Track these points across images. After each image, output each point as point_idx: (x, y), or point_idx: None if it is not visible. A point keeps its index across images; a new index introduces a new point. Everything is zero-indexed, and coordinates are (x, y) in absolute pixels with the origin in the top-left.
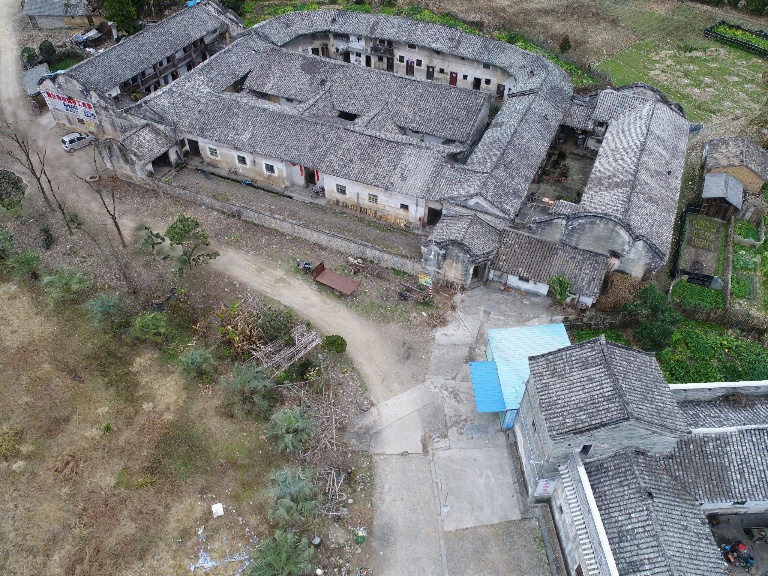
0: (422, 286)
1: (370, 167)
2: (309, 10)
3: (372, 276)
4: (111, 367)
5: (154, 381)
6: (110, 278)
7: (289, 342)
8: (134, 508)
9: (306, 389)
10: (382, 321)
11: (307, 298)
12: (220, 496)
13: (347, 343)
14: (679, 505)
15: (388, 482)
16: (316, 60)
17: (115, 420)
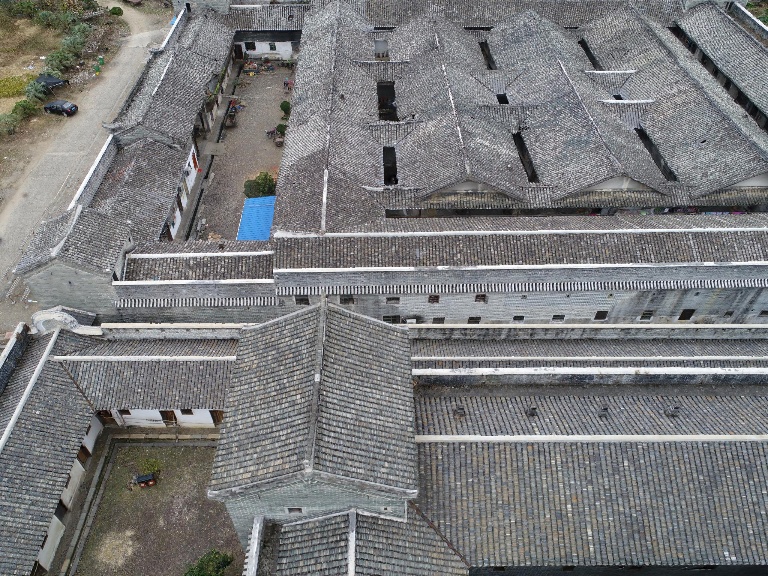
0: None
1: None
2: None
3: (155, 1)
4: (6, 24)
5: (26, 27)
6: (15, 0)
7: (90, 3)
8: (4, 56)
9: (96, 24)
10: (151, 14)
11: (116, 6)
12: (45, 55)
13: (129, 19)
14: (222, 25)
15: (124, 53)
16: None
17: (3, 37)
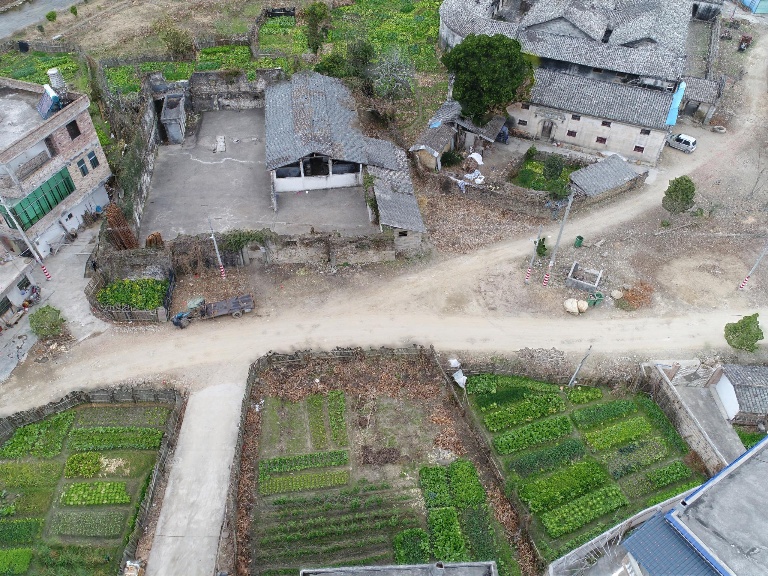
0: (723, 24)
1: (683, 0)
2: (466, 7)
3: None
4: None
5: None
6: None
7: None
8: None
9: None
10: None
11: (762, 50)
12: None
13: None
14: None
15: None
16: (573, 2)
17: None
